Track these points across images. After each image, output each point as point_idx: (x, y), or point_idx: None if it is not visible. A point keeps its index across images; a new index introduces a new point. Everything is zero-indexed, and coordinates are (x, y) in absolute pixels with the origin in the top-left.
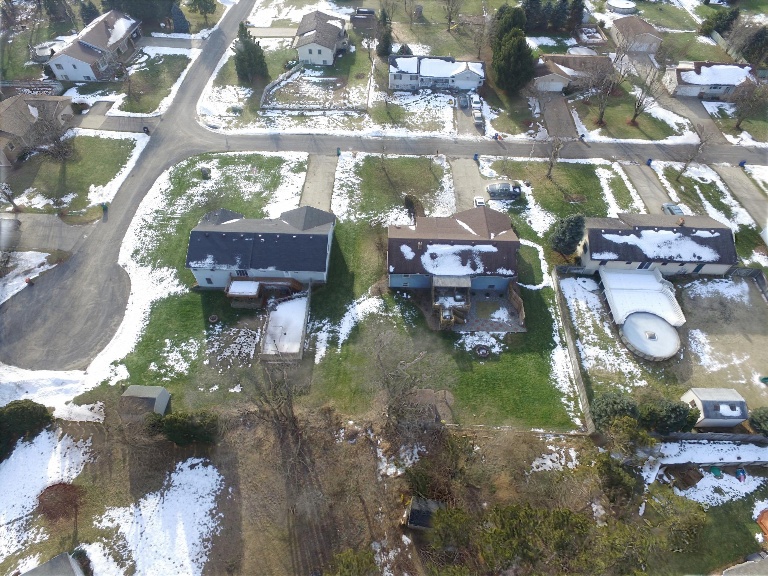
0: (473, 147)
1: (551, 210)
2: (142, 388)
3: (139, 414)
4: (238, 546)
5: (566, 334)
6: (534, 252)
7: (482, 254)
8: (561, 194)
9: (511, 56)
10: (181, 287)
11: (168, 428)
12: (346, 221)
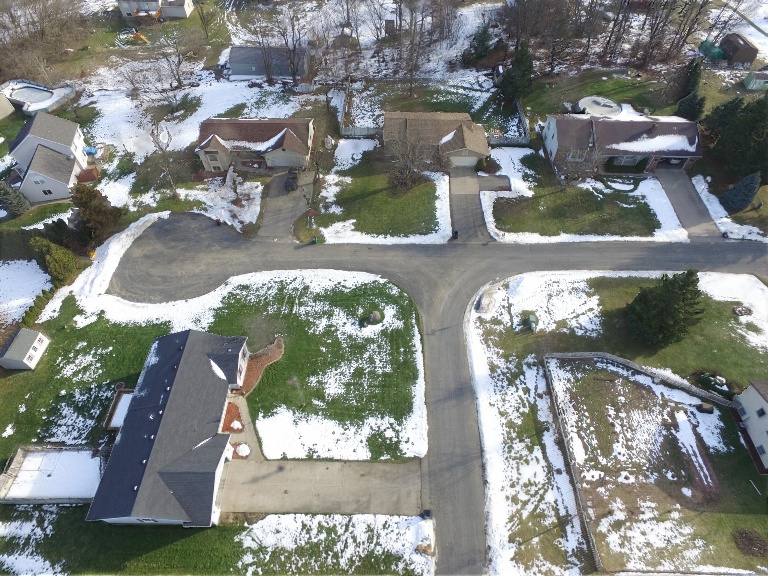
0: None
1: None
2: (28, 342)
3: None
4: None
5: None
6: None
7: None
8: None
9: None
10: None
11: None
12: (238, 547)
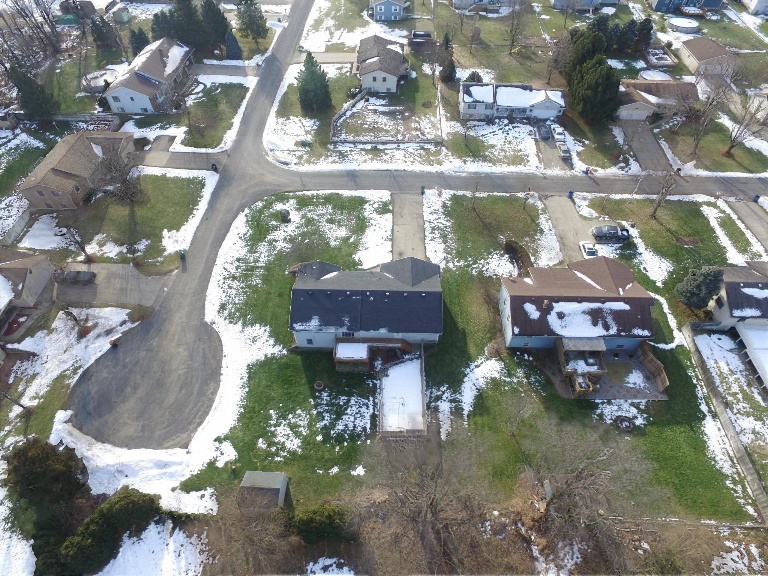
0: (564, 183)
1: (665, 255)
2: (261, 475)
3: (263, 508)
4: None
5: (715, 403)
6: (657, 305)
7: (614, 313)
8: (671, 236)
9: (598, 85)
10: (278, 348)
11: (302, 528)
12: (445, 270)
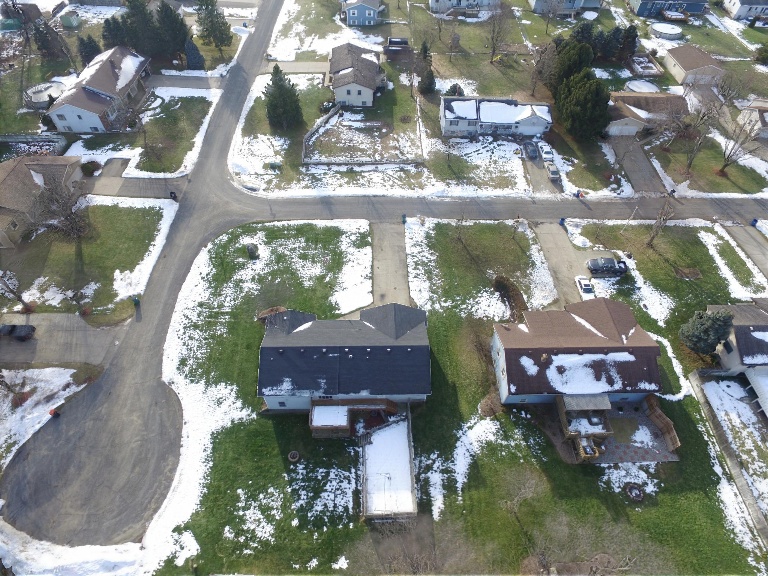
0: (555, 208)
1: (665, 290)
2: None
3: None
4: None
5: (729, 463)
6: (661, 348)
7: (618, 365)
8: (670, 268)
9: (587, 101)
10: (246, 411)
11: None
12: (431, 312)
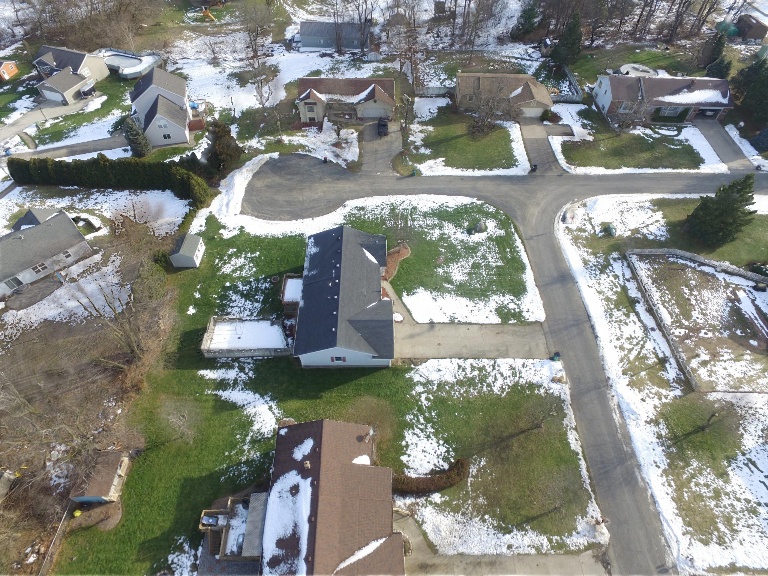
0: None
1: None
2: (195, 244)
3: None
4: (54, 338)
5: None
6: None
7: None
8: None
9: None
10: None
11: None
12: (410, 381)
